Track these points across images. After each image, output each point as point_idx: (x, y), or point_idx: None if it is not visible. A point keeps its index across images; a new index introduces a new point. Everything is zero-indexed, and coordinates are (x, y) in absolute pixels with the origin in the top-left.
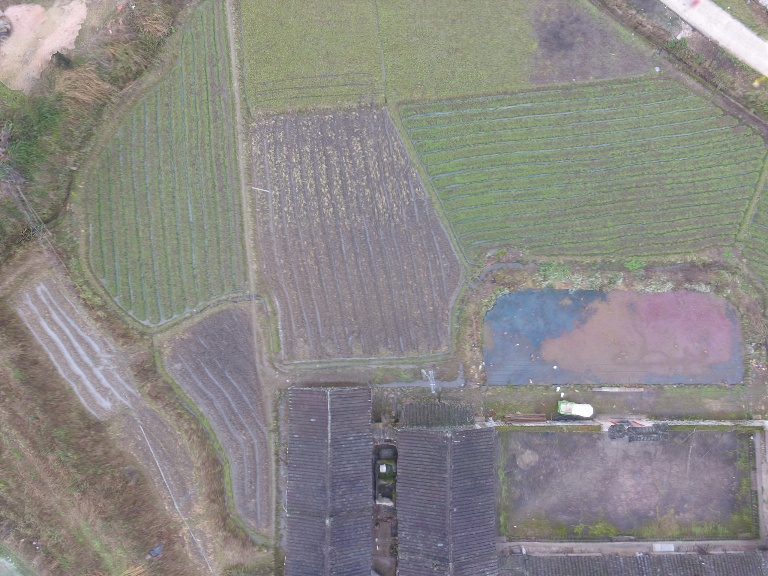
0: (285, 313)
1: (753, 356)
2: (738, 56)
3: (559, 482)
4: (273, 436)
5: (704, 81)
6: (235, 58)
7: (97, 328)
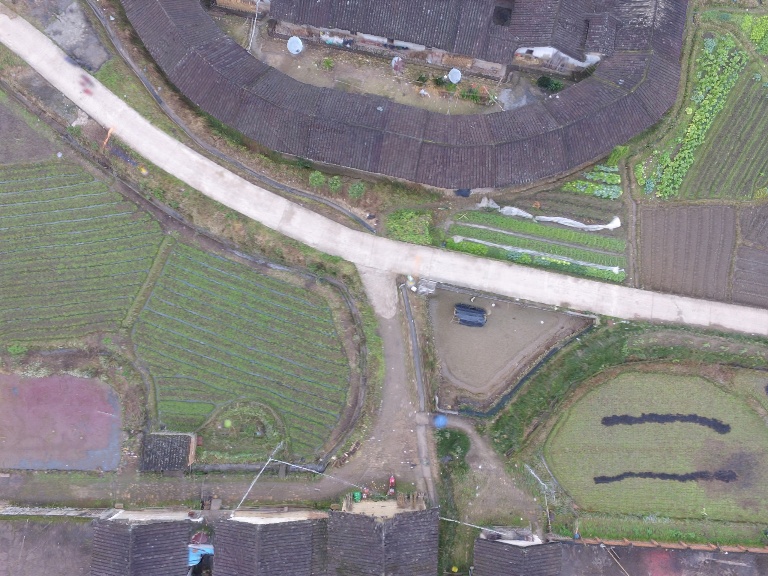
0: None
1: (127, 443)
2: (129, 144)
3: None
4: None
5: (102, 167)
6: None
7: None
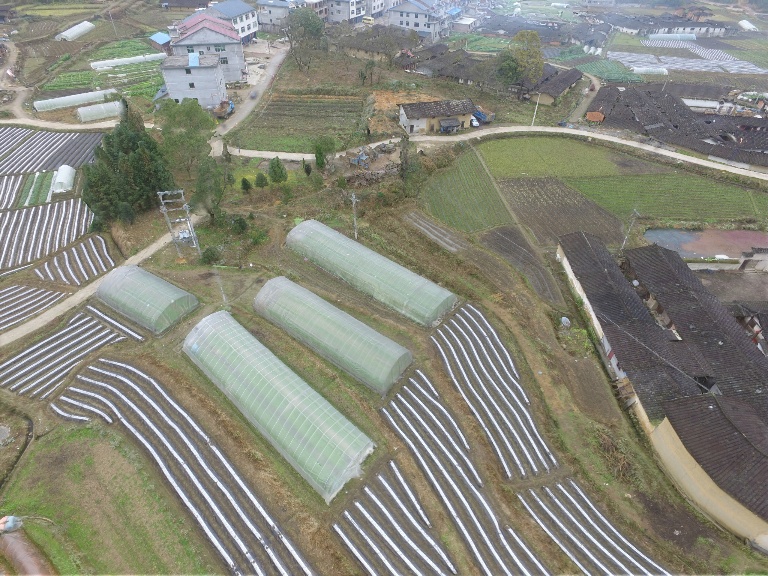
0: (536, 230)
1: None
2: None
3: (732, 292)
4: (549, 267)
5: (699, 174)
6: (485, 165)
7: (444, 225)
